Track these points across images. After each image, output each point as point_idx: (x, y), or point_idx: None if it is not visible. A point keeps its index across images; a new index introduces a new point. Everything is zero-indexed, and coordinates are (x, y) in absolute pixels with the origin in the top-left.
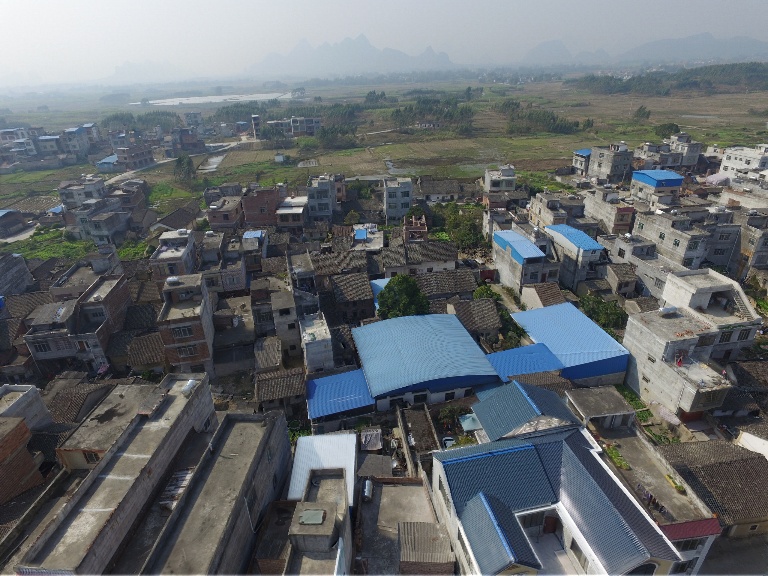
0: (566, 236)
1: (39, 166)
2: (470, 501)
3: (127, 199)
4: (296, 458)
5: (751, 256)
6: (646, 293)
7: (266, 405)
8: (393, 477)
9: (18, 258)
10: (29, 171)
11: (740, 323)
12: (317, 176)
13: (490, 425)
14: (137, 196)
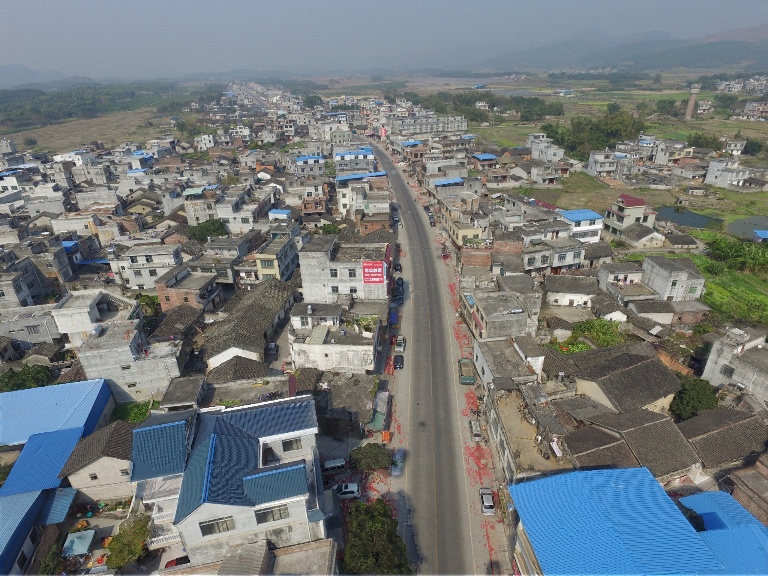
0: None
1: None
2: (245, 490)
3: None
4: None
5: (58, 275)
6: (26, 346)
7: None
8: None
9: None
10: None
11: (132, 311)
12: None
13: (166, 468)
14: None
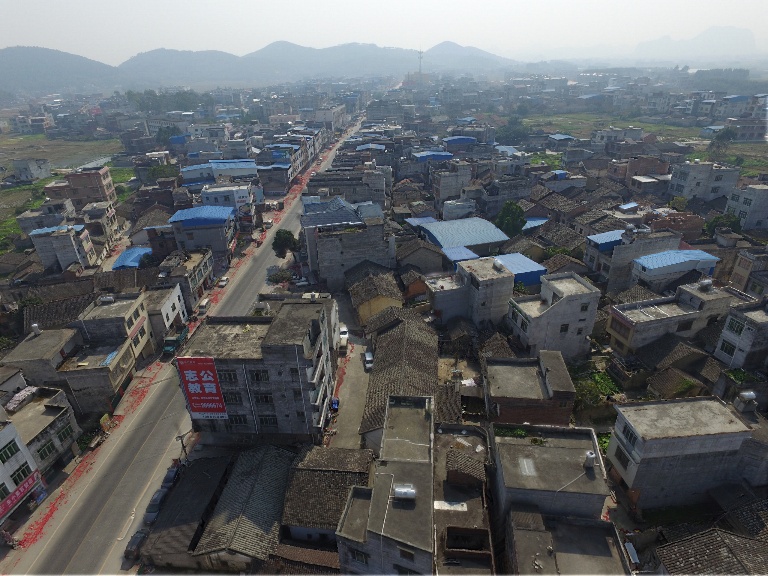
0: (662, 252)
1: (676, 122)
2: None
3: (620, 148)
4: (362, 202)
5: None
6: None
7: (413, 213)
8: None
9: (496, 150)
10: (667, 125)
11: None
12: (725, 164)
13: None
14: (632, 148)
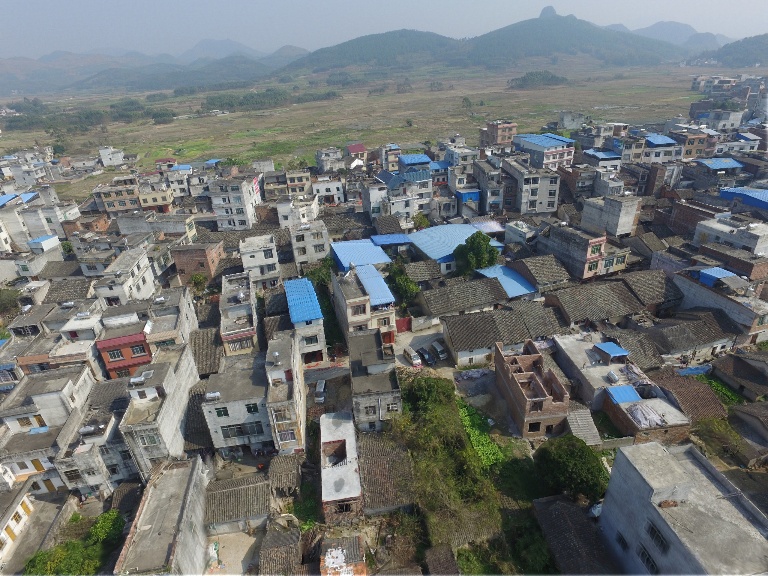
0: None
1: None
2: None
3: None
4: None
5: None
6: None
7: None
8: (446, 199)
9: None
10: None
11: None
12: None
13: None
14: None
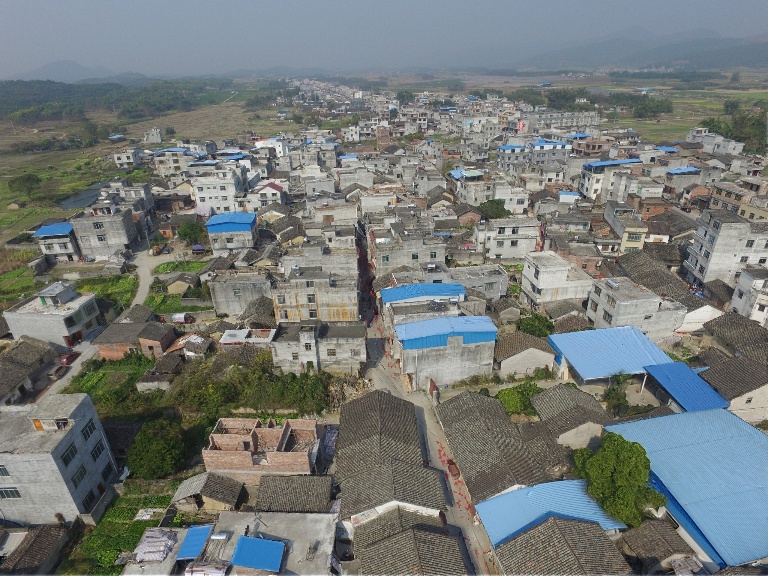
0: (433, 294)
1: None
2: None
3: None
4: None
5: None
6: None
7: None
8: None
9: None
10: None
11: None
12: None
13: None
14: None
